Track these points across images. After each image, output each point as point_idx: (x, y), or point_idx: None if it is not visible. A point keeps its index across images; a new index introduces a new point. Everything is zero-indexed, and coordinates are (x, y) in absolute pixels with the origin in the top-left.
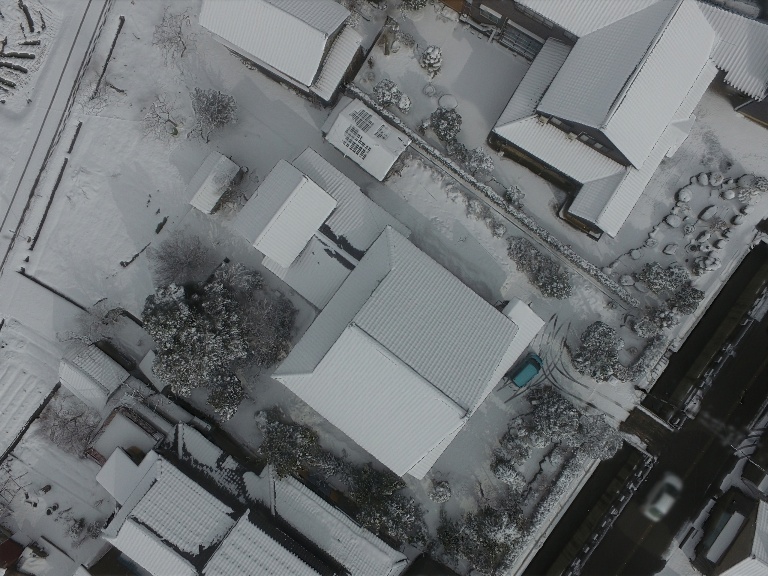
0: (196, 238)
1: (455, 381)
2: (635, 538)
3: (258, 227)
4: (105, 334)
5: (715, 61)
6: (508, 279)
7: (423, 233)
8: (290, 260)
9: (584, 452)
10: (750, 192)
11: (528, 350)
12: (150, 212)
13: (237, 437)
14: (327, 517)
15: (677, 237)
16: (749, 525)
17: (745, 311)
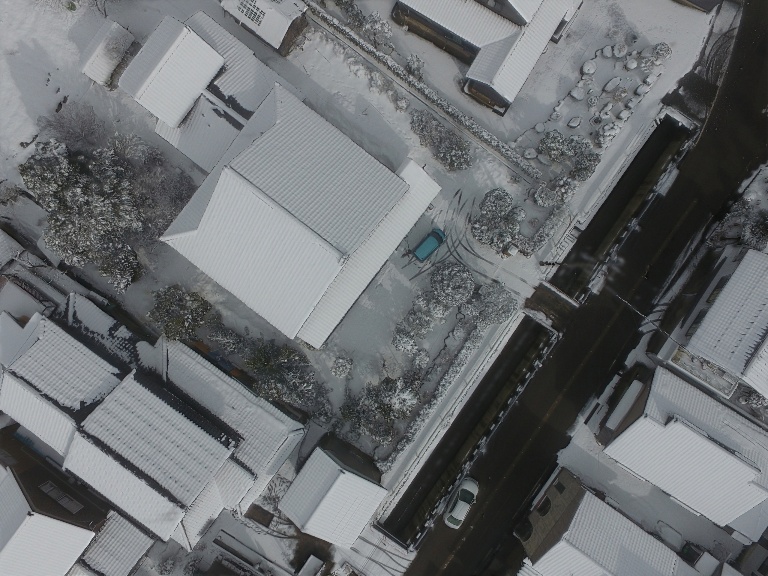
0: (89, 108)
1: (335, 227)
2: (540, 414)
3: (140, 81)
4: (4, 215)
5: None
6: (411, 153)
7: (325, 107)
8: (177, 119)
9: (483, 321)
10: (653, 61)
11: (432, 226)
12: (50, 91)
13: (139, 317)
14: (222, 385)
15: (582, 110)
16: (646, 390)
17: (651, 186)
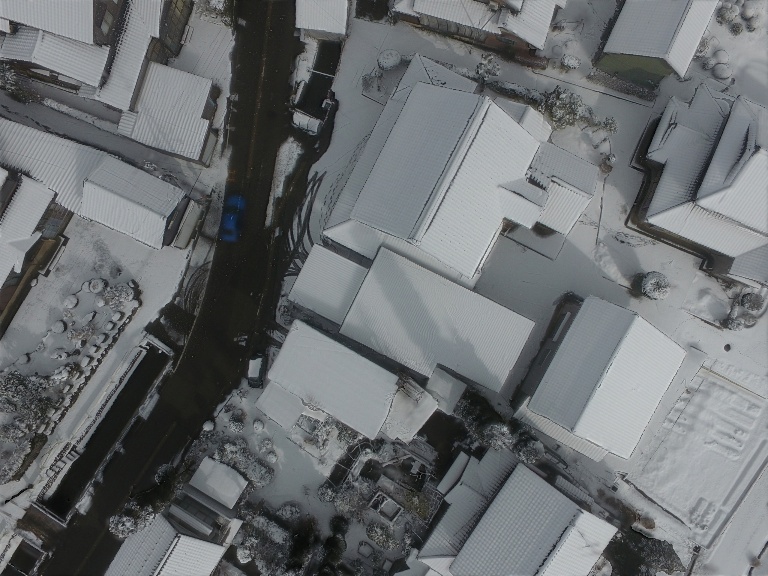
0: None
1: None
2: None
3: None
4: None
5: (46, 184)
6: None
7: None
8: None
9: None
10: None
11: None
12: None
13: None
14: None
15: (65, 341)
16: None
17: (138, 409)
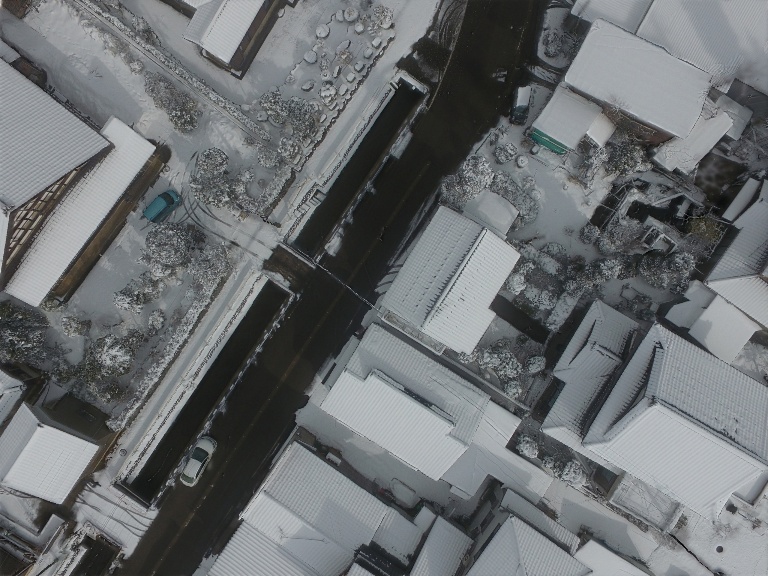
0: None
1: (5, 180)
2: (279, 375)
3: None
4: None
5: None
6: (145, 115)
7: (59, 69)
8: None
9: None
10: (378, 24)
11: (170, 188)
12: None
13: None
14: None
15: (315, 74)
16: None
17: (388, 150)
